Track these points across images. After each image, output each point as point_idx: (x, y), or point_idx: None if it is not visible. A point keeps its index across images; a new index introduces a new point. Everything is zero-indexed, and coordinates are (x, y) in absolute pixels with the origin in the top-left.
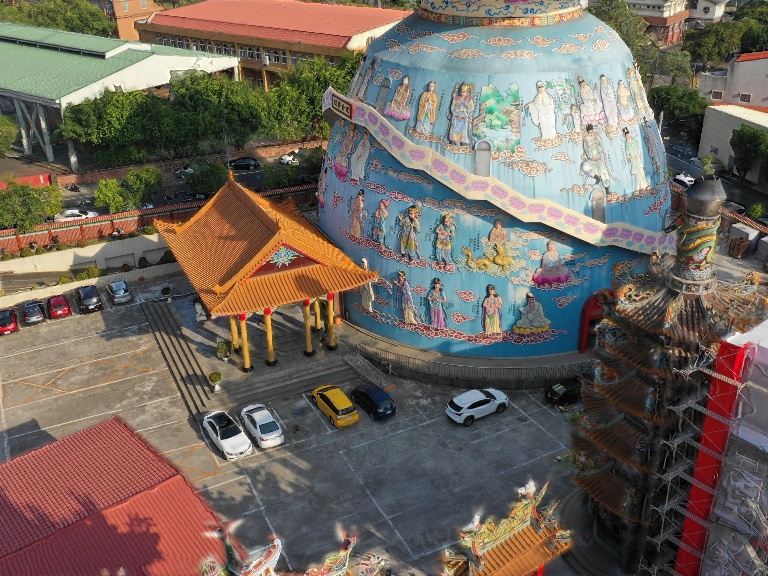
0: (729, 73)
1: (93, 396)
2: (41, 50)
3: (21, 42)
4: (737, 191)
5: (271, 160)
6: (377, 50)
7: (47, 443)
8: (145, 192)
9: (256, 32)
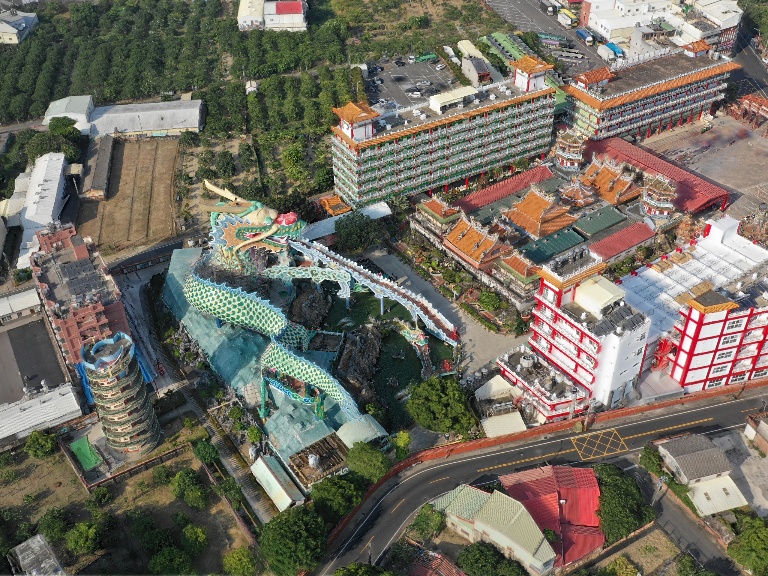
0: None
1: (758, 200)
2: None
3: None
4: None
5: None
6: None
7: (737, 197)
8: None
9: None
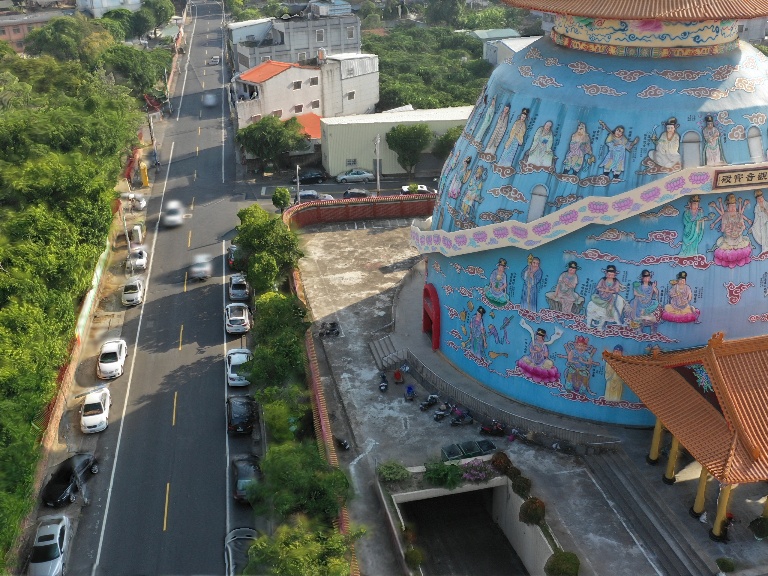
0: (261, 95)
1: None
2: None
3: None
4: (424, 183)
5: (59, 447)
6: (694, 105)
7: None
8: (347, 568)
9: None
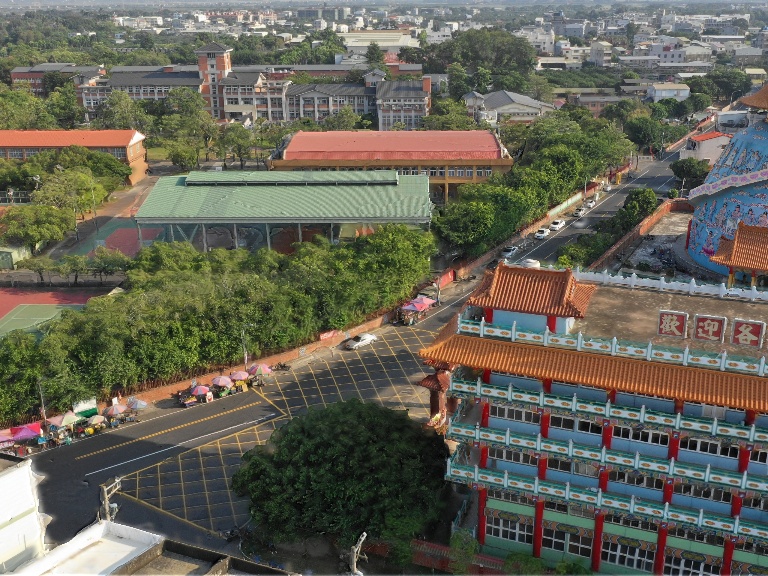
0: (698, 148)
1: None
2: (316, 187)
3: (284, 183)
4: None
5: None
6: None
7: None
8: (585, 259)
9: (408, 156)
